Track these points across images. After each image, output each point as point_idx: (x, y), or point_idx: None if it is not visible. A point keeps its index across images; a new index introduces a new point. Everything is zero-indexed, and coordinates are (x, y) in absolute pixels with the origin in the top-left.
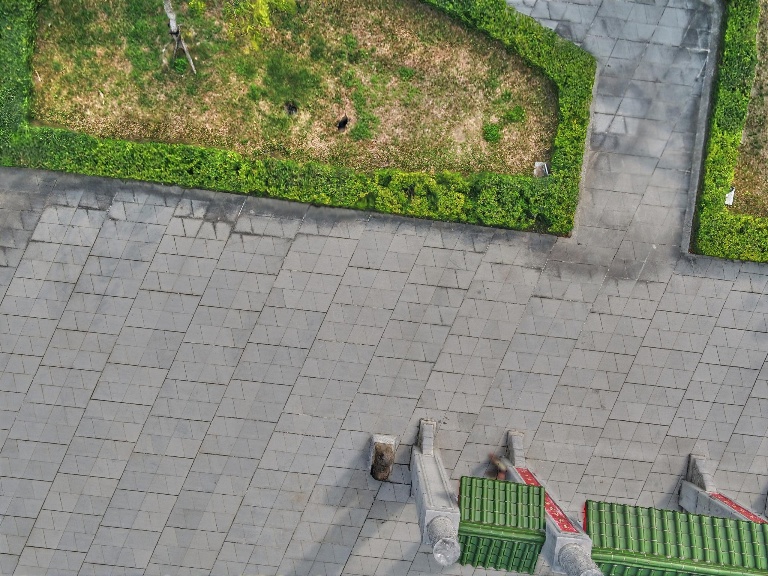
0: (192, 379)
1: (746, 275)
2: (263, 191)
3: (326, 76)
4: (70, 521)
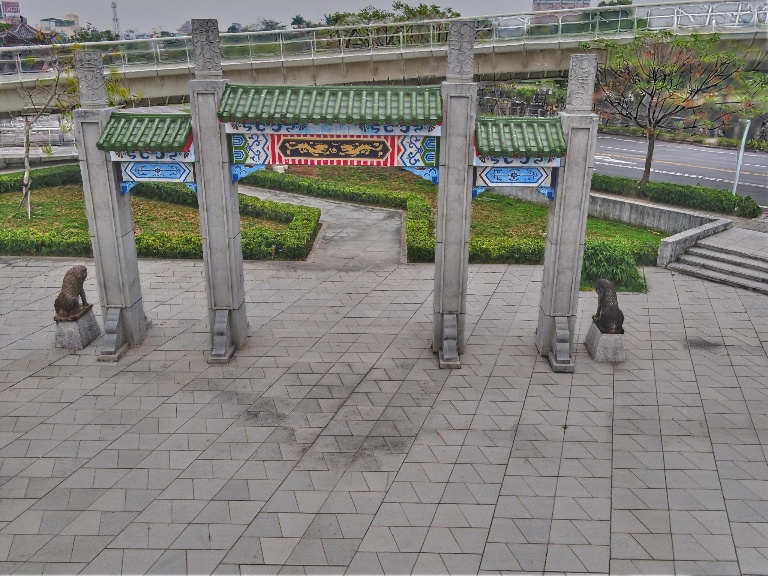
0: None
1: None
2: (48, 243)
3: None
4: None
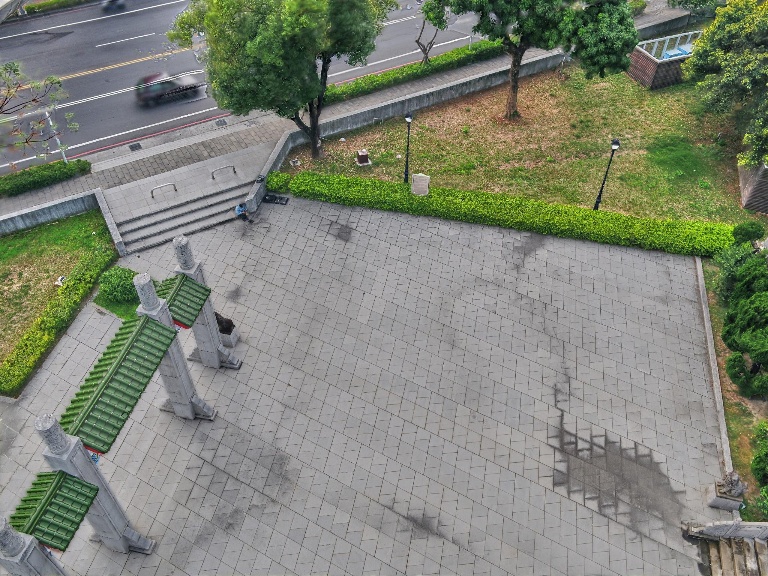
0: None
1: (51, 366)
2: None
3: None
4: None
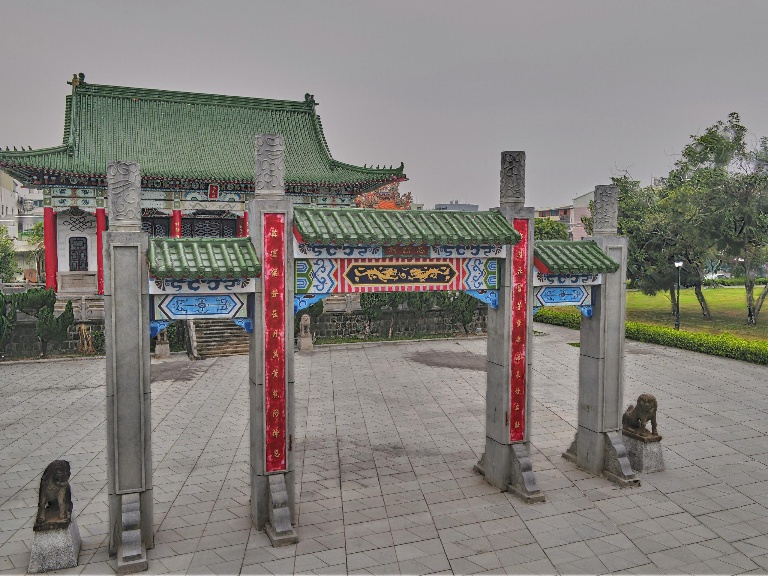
0: None
1: None
2: None
3: None
4: None
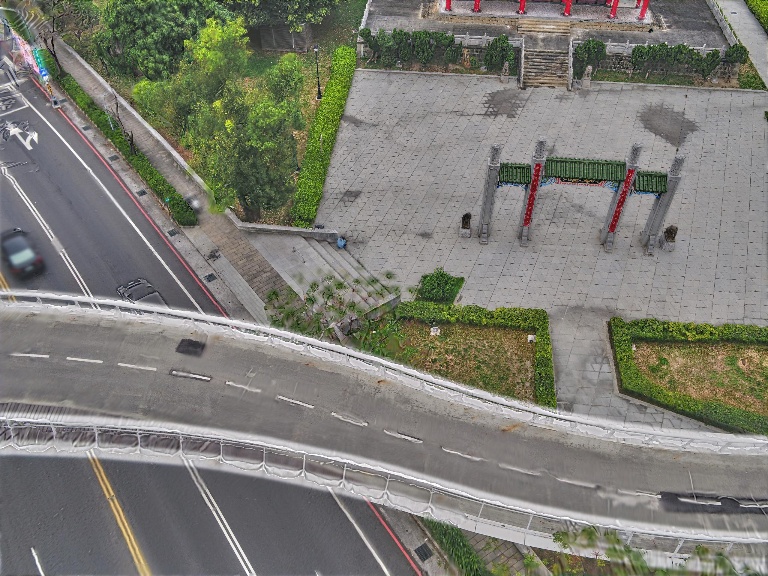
0: (764, 267)
1: None
2: None
3: (764, 381)
4: None
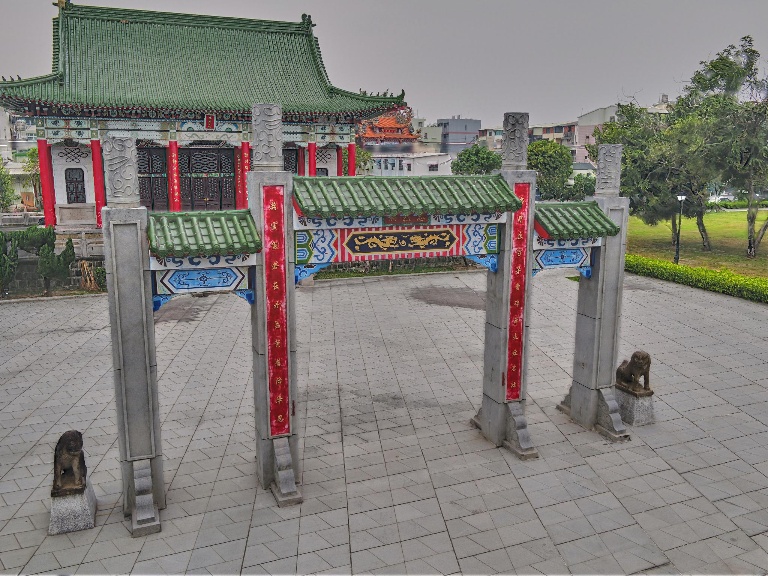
0: None
1: None
2: None
3: None
4: (764, 350)
